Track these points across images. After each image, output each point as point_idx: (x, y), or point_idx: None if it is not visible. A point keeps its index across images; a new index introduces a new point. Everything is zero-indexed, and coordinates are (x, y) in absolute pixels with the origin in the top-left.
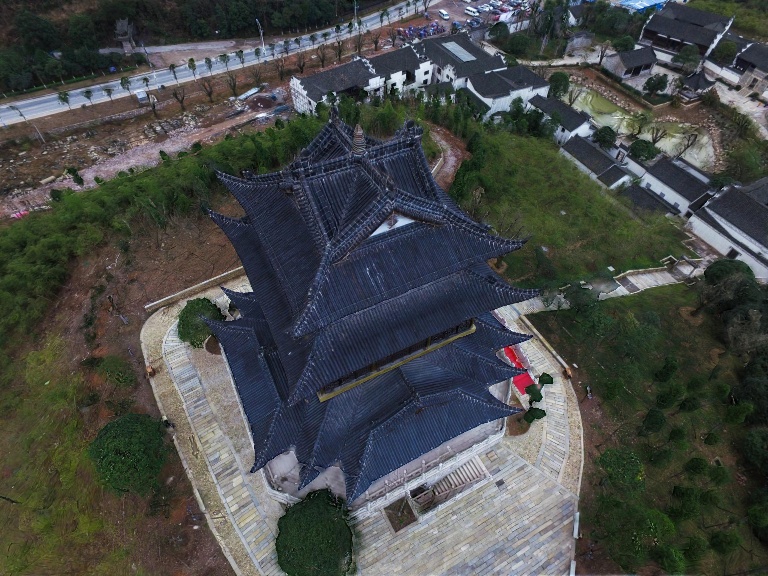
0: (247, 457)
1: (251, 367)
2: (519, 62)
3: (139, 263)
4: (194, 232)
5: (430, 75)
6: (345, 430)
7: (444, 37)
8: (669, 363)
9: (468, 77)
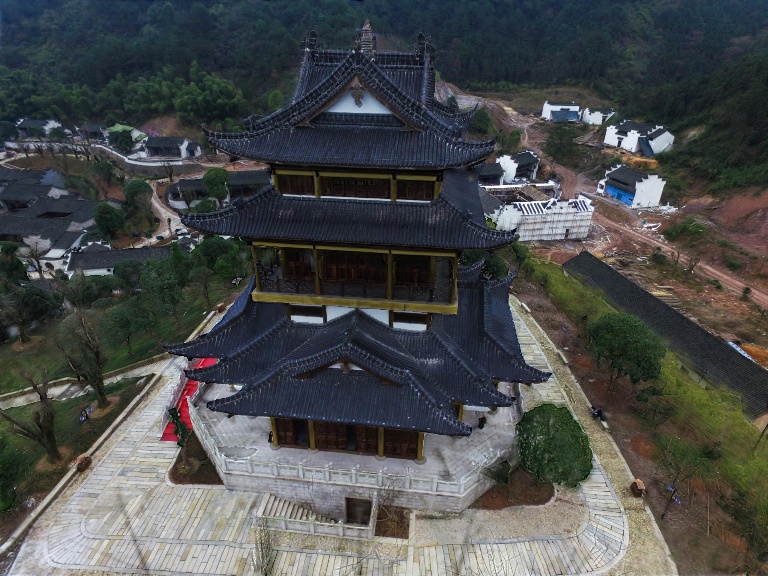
0: None
1: (497, 325)
2: None
3: None
4: None
5: None
6: None
7: None
8: None
9: None
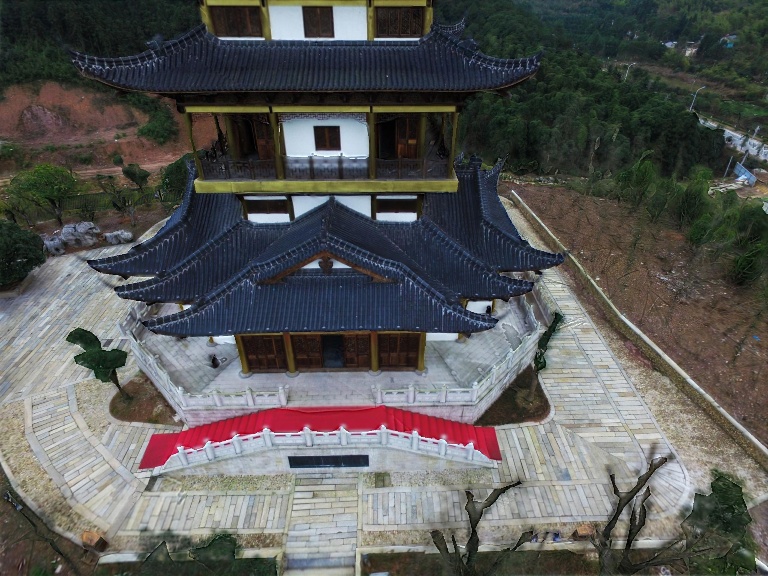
0: None
1: None
2: None
3: None
4: (623, 214)
5: None
6: None
7: None
8: None
9: None
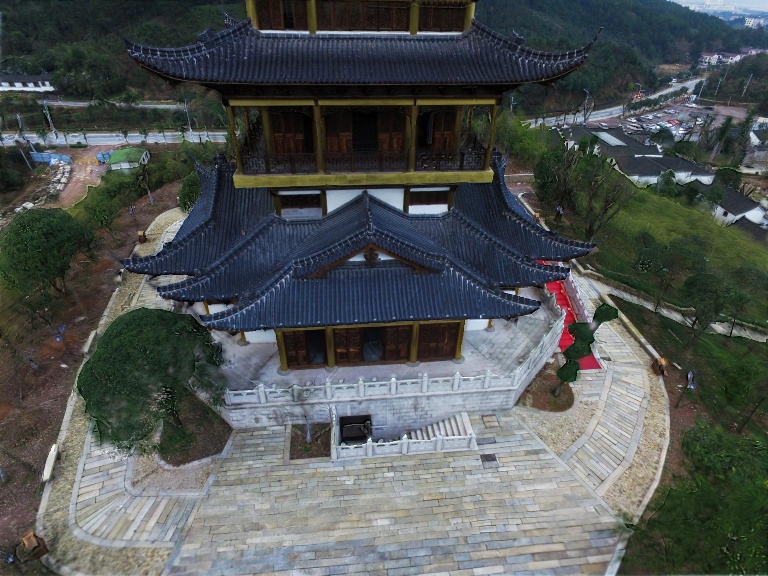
0: None
1: None
2: (679, 156)
3: None
4: None
5: None
6: (268, 268)
7: None
8: None
9: (614, 158)
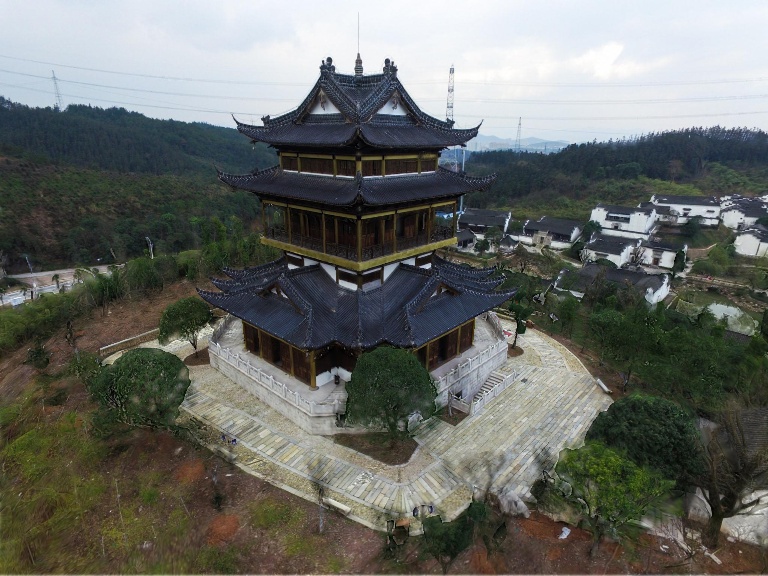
0: (267, 416)
1: (265, 309)
2: None
3: (83, 328)
4: (144, 302)
5: None
6: (379, 321)
7: None
8: None
9: None
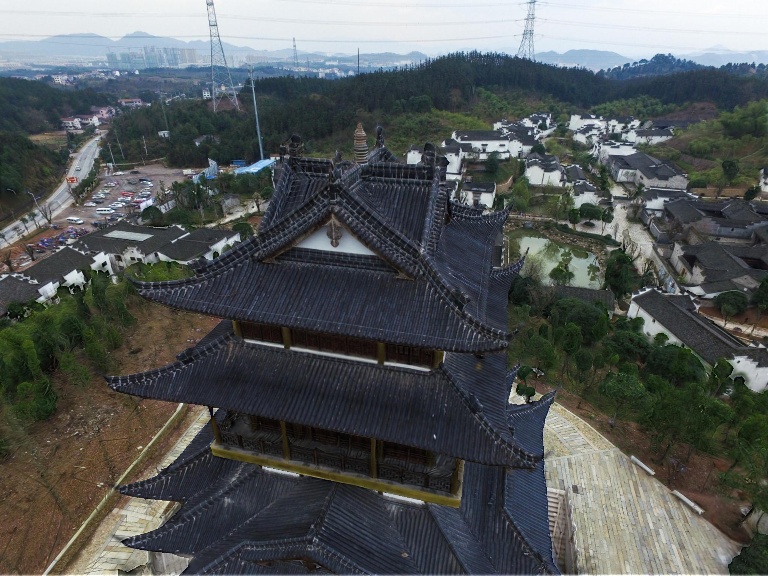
0: None
1: None
2: (195, 227)
3: None
4: None
5: (109, 265)
6: (473, 543)
7: (101, 230)
8: (541, 327)
9: (157, 251)
